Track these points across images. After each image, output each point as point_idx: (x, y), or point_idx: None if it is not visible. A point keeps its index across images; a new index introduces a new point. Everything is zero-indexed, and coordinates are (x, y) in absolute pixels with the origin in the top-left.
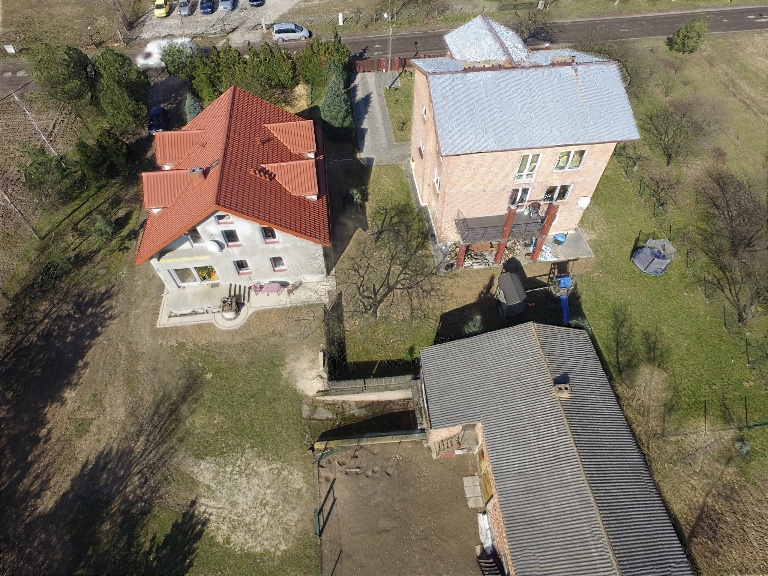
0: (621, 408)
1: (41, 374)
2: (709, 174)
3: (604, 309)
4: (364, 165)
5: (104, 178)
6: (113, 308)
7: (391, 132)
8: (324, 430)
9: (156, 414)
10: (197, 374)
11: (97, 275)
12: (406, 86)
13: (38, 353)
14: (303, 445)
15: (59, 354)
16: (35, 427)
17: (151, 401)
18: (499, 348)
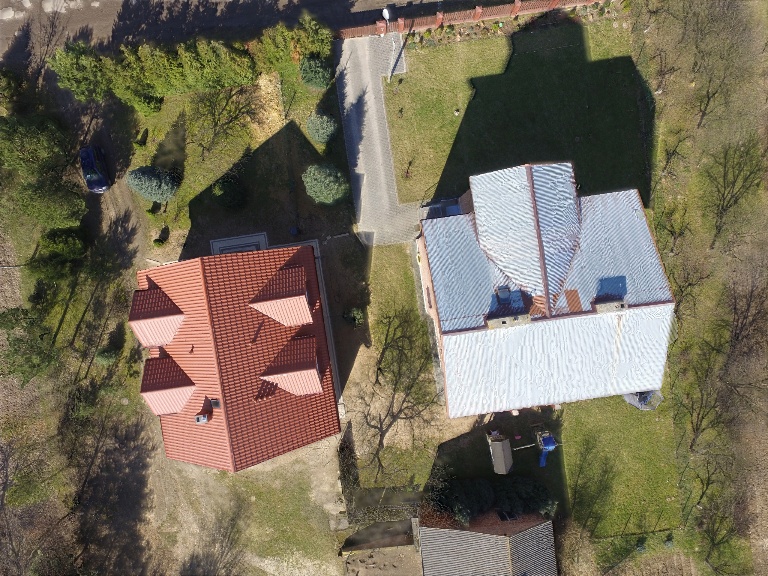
0: (560, 573)
1: (120, 500)
2: (751, 260)
3: (580, 437)
4: (363, 246)
5: (71, 277)
6: (151, 439)
7: (393, 182)
8: (348, 536)
9: (222, 528)
10: (243, 497)
11: (122, 406)
12: (414, 73)
13: (108, 483)
14: (334, 550)
15: (126, 483)
16: (137, 540)
17: (214, 518)
18: (480, 548)
